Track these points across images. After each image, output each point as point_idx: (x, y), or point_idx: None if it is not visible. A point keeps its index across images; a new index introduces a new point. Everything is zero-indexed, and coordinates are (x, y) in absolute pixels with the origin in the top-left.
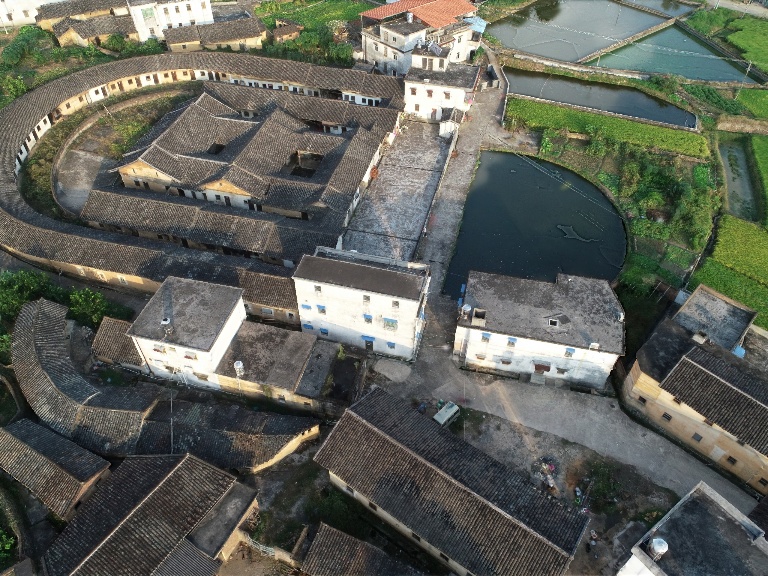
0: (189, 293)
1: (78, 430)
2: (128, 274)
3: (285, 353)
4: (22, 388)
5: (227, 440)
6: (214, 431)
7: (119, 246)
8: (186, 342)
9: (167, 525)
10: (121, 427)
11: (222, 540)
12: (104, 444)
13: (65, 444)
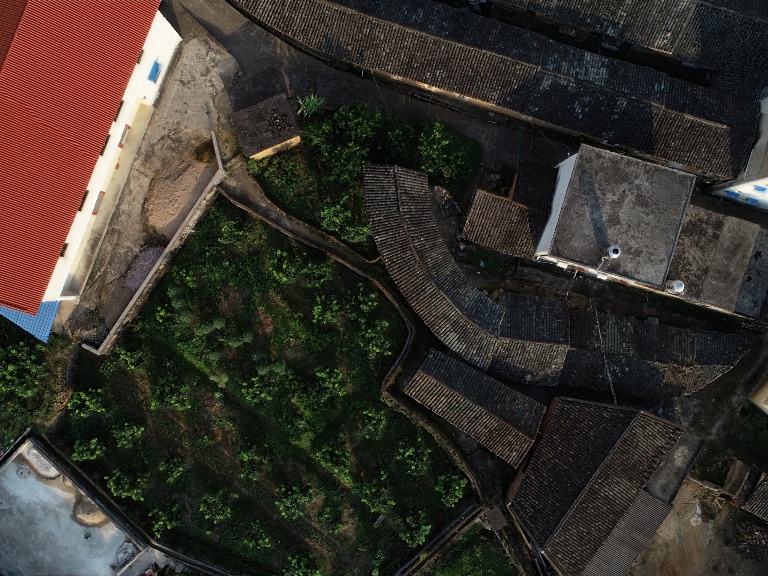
0: (618, 181)
1: (492, 359)
2: (485, 102)
3: (721, 255)
4: (413, 306)
5: (658, 372)
6: (644, 362)
7: (466, 49)
8: (631, 272)
9: (627, 482)
10: (543, 360)
11: (674, 489)
12: (525, 376)
13: (492, 385)
